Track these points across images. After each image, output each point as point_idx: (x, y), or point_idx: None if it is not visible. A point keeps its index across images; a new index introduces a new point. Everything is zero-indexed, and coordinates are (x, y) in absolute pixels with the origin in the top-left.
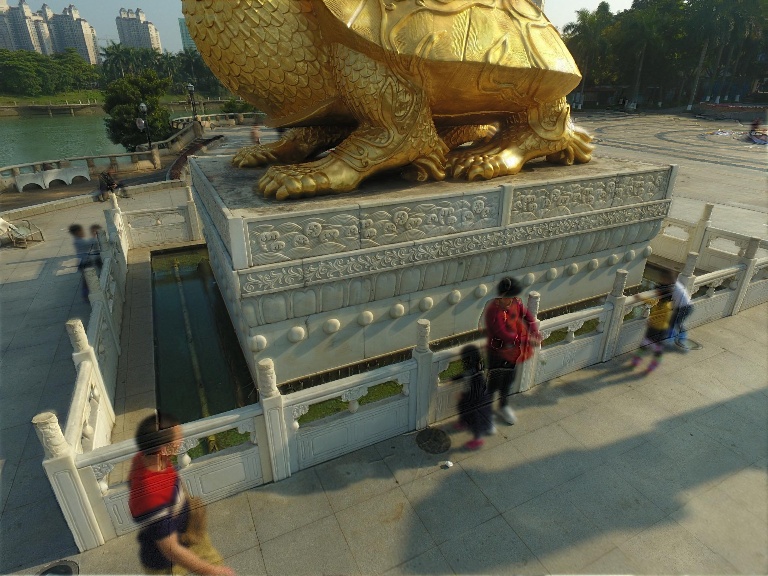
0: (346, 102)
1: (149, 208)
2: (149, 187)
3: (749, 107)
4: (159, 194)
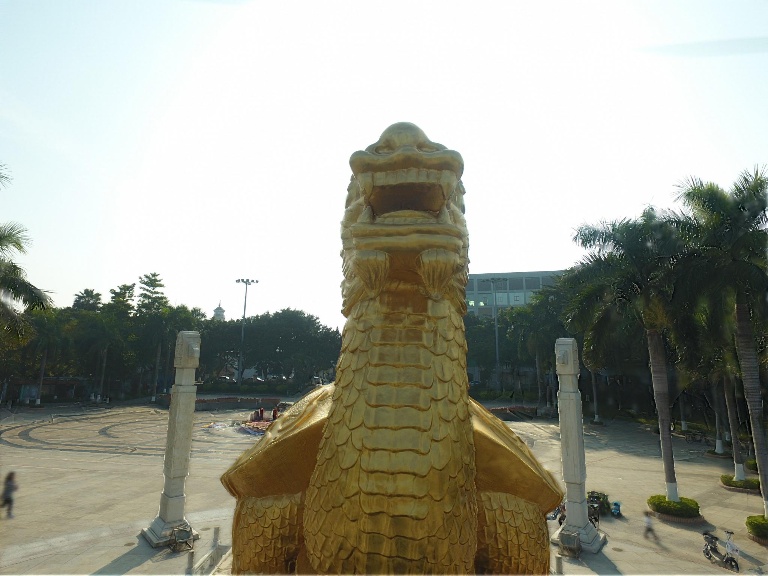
0: (505, 562)
1: None
2: None
3: (208, 399)
4: None
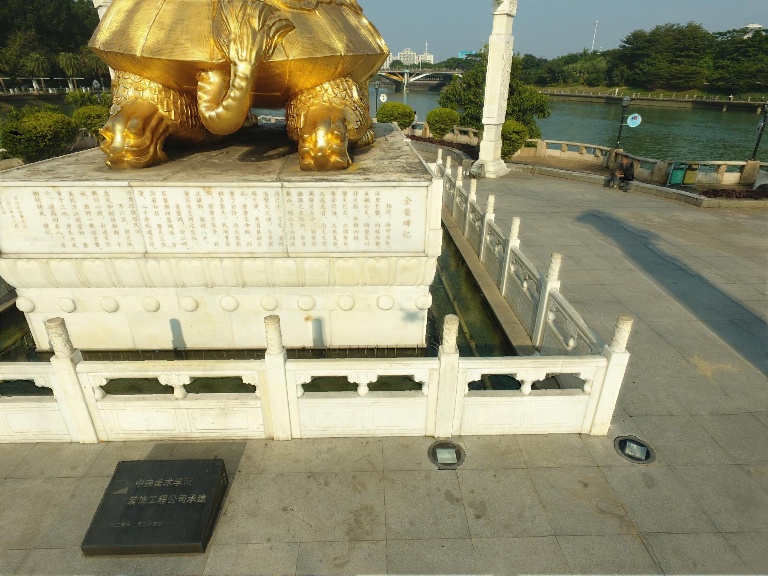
0: None
1: (572, 195)
2: (663, 192)
3: None
4: (644, 198)
